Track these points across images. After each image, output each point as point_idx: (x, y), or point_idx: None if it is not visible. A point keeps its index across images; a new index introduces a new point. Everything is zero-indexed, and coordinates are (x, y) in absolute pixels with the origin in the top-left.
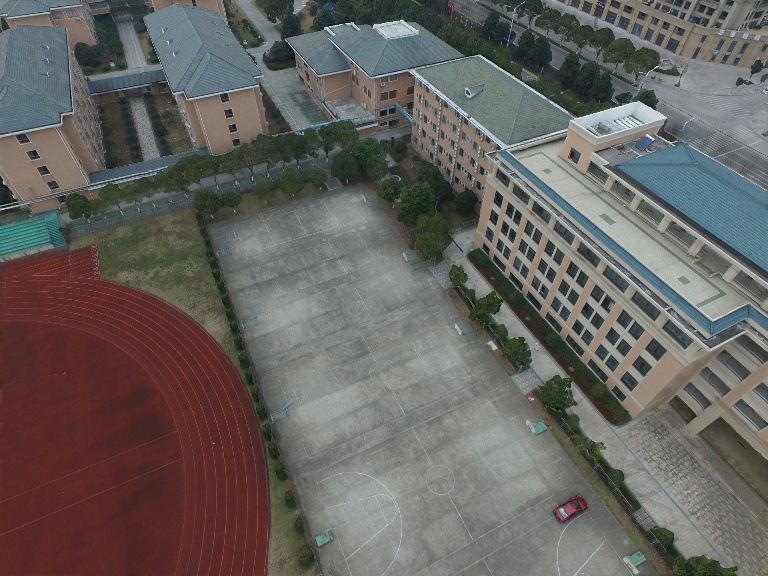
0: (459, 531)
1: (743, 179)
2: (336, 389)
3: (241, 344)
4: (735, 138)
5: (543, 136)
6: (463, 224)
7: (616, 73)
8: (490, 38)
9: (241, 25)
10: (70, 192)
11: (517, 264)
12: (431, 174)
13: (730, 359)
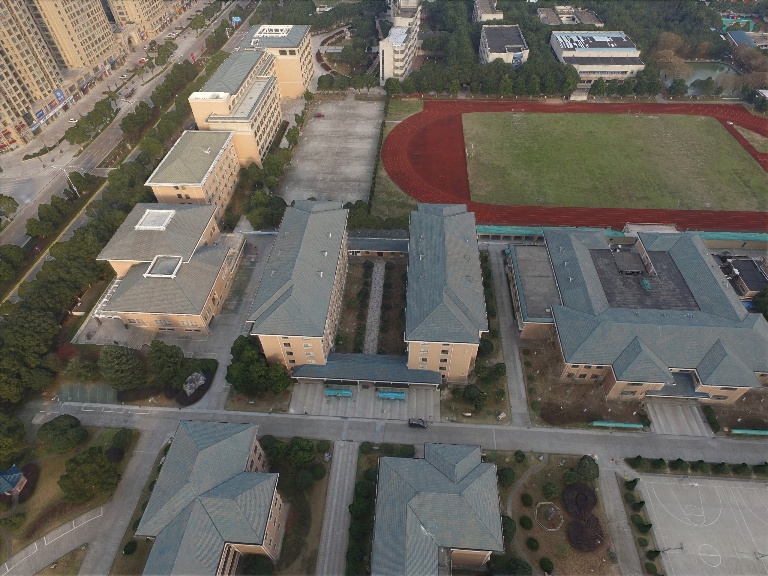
0: None
1: None
2: None
3: None
4: (60, 171)
5: None
6: None
7: None
8: None
9: None
10: None
11: None
12: None
13: None
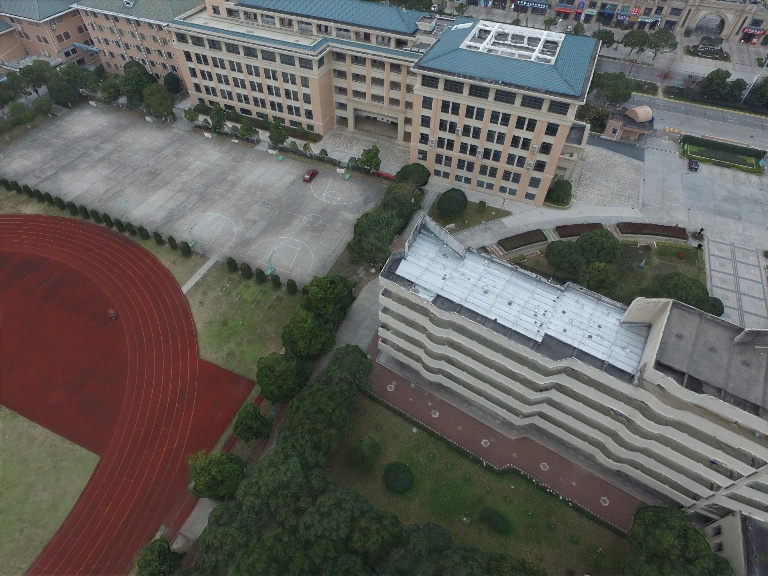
0: (262, 208)
1: None
2: (151, 195)
3: (62, 201)
4: None
5: None
6: None
7: None
8: None
9: None
10: None
11: (223, 94)
12: (134, 66)
13: (338, 74)
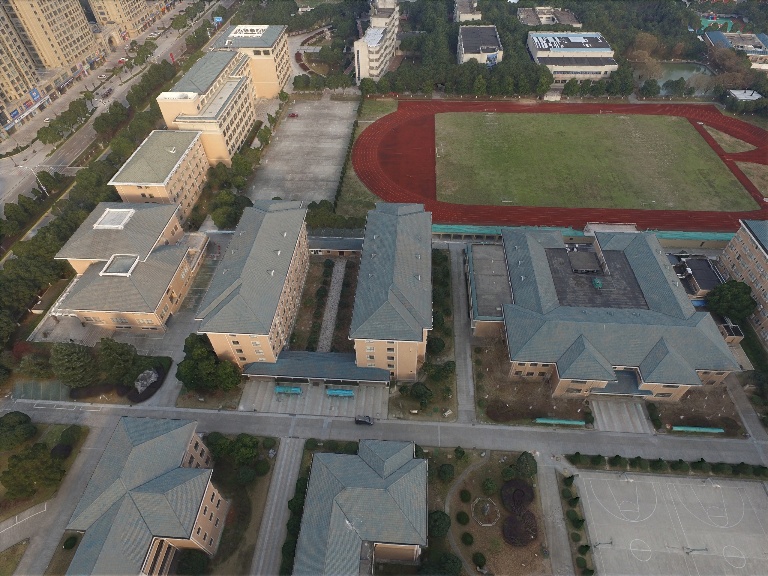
0: None
1: None
2: None
3: None
4: None
5: None
6: None
7: None
8: None
9: None
10: None
11: None
12: (223, 164)
13: None
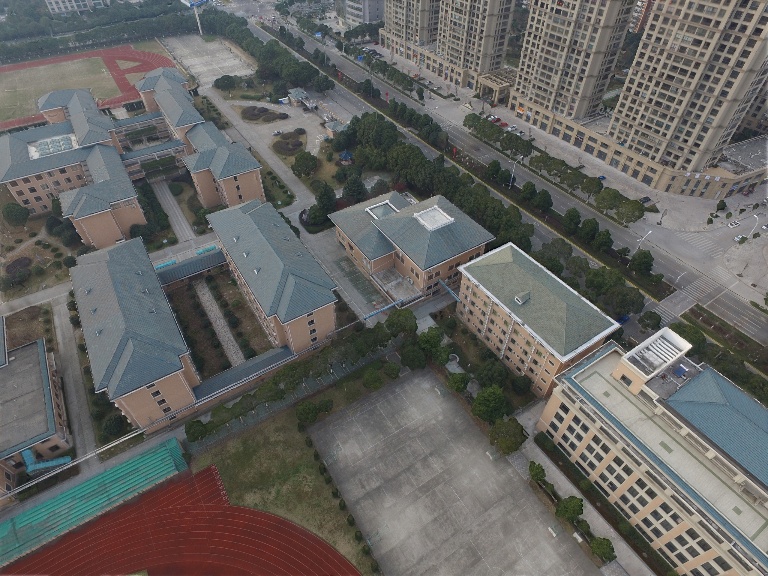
0: None
1: (761, 409)
2: None
3: (378, 569)
4: (717, 281)
5: (588, 342)
6: (524, 407)
7: (607, 213)
8: (492, 179)
9: (268, 178)
10: (180, 412)
11: (584, 457)
12: (496, 372)
13: None
